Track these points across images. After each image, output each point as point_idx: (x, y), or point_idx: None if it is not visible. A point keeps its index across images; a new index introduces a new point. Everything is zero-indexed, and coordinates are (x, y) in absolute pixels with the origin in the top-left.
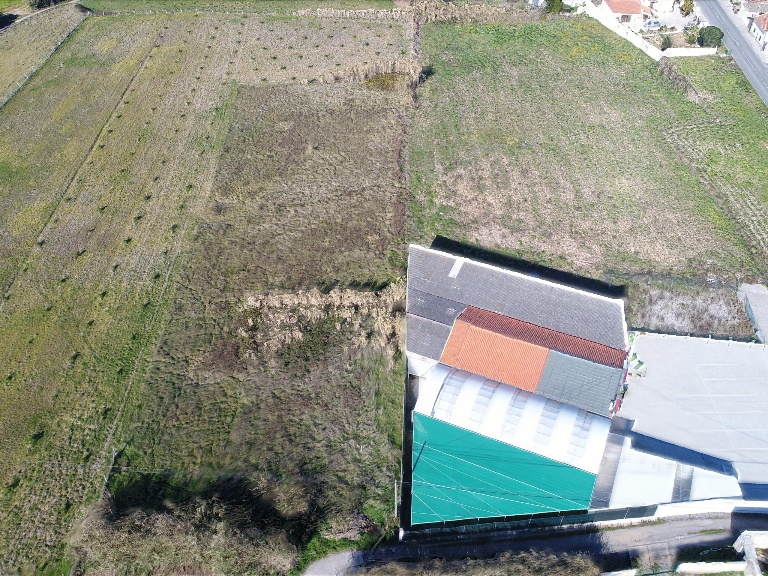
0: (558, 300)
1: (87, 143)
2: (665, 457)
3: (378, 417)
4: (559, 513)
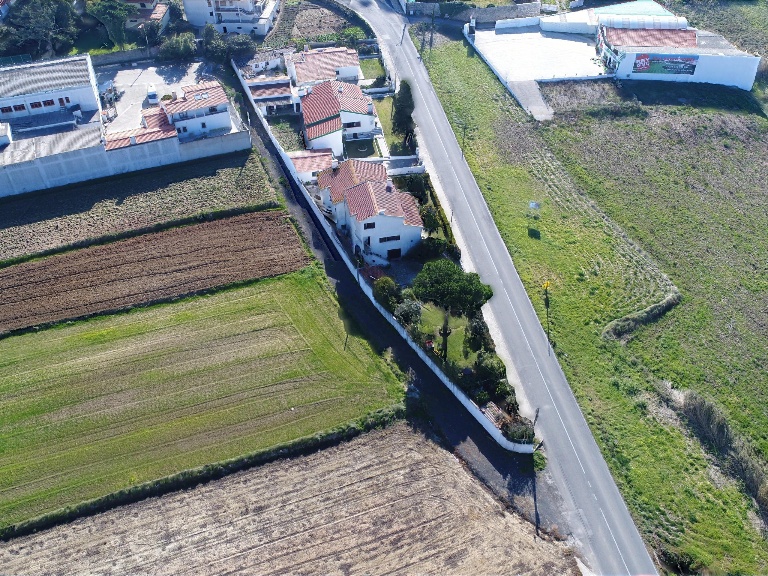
0: (655, 52)
1: None
2: (570, 36)
3: None
4: (603, 6)
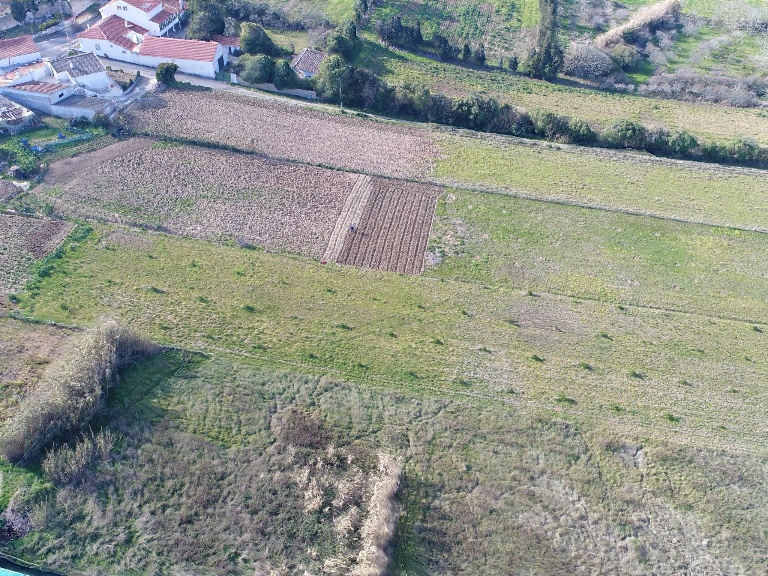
0: None
1: (763, 316)
2: None
3: (147, 574)
4: None
